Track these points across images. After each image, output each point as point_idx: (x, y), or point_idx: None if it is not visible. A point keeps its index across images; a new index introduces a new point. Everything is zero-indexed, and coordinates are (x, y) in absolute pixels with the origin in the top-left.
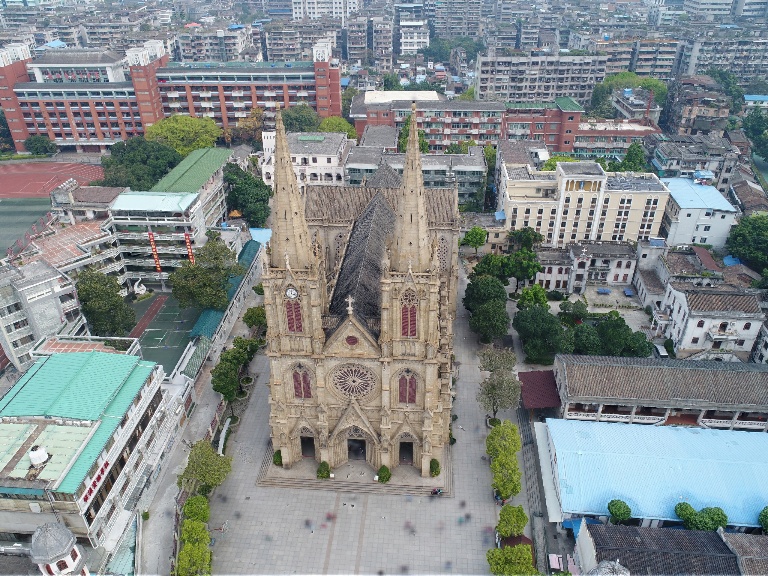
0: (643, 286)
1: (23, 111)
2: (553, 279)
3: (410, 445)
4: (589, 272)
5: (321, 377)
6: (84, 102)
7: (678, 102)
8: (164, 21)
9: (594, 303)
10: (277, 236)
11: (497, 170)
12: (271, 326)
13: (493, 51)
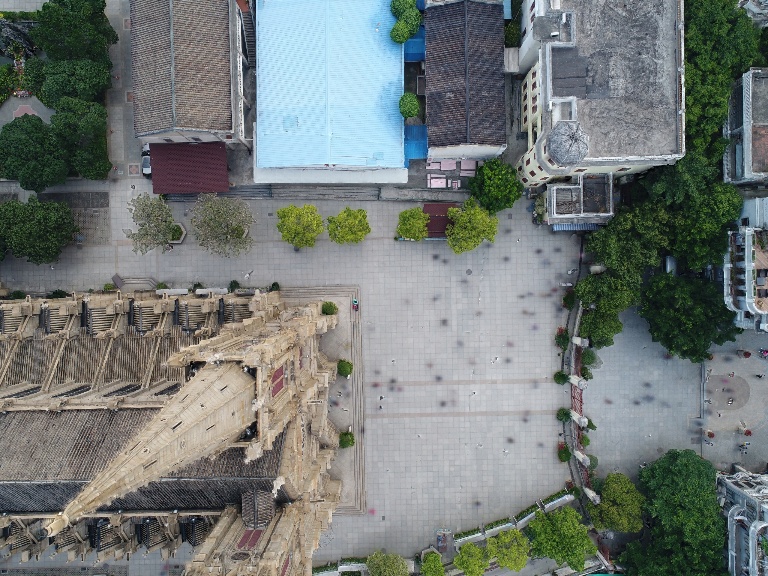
0: None
1: None
2: None
3: None
4: None
5: (310, 487)
6: None
7: None
8: None
9: None
10: None
11: None
12: None
13: None
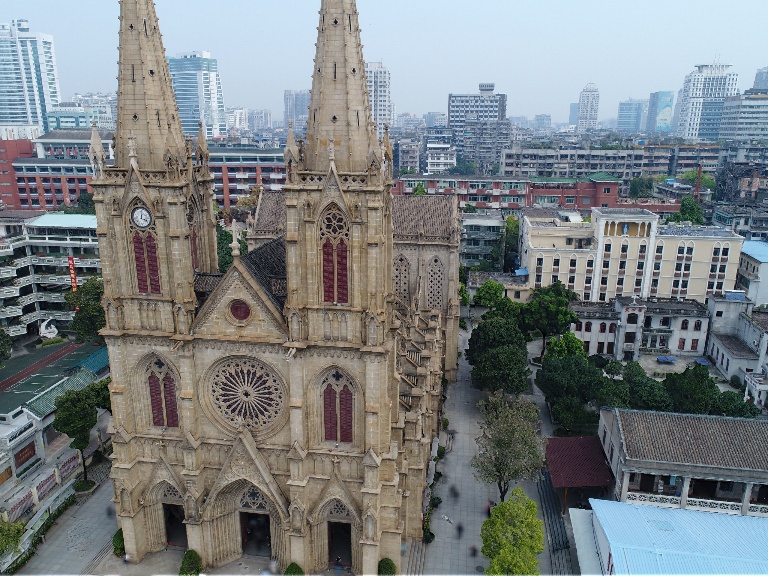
0: (723, 351)
1: (19, 187)
2: (593, 340)
3: (346, 530)
4: (643, 337)
5: (189, 380)
6: (82, 179)
7: (733, 178)
8: (189, 126)
9: (654, 371)
10: (121, 114)
11: (520, 236)
12: (107, 279)
13: (518, 145)
